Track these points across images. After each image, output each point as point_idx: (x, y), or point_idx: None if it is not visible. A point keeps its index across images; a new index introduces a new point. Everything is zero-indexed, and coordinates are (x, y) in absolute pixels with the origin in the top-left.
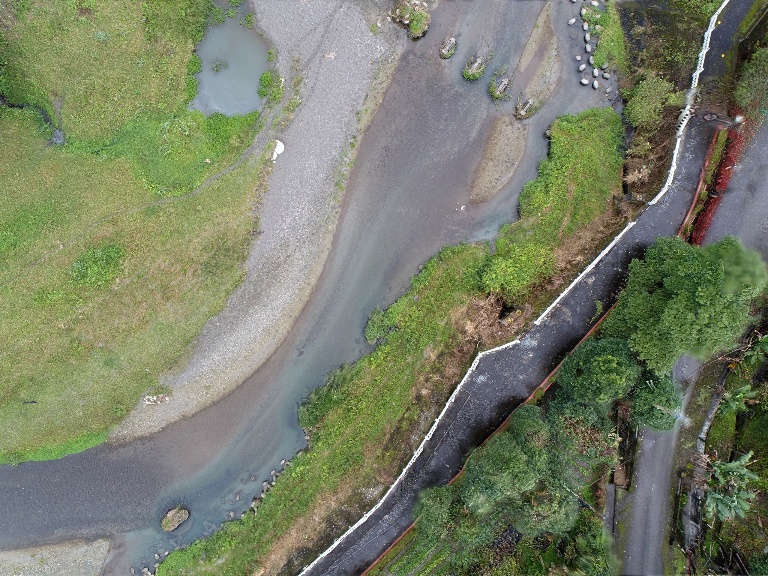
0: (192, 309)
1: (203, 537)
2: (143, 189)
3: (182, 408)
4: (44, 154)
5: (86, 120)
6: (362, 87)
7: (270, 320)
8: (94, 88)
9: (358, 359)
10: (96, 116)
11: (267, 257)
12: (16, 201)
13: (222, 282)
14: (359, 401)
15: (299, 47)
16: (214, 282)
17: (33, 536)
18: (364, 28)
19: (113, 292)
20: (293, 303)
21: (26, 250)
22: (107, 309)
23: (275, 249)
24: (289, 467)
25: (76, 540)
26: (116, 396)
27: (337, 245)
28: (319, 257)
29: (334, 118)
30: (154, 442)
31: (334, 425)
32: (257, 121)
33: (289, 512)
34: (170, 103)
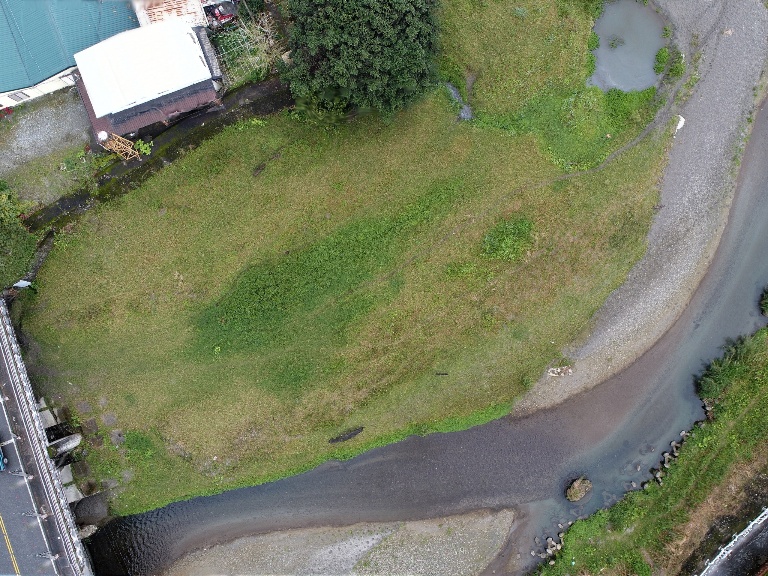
0: (598, 282)
1: (605, 507)
2: (551, 164)
3: (584, 380)
4: (456, 129)
5: (497, 95)
6: (758, 63)
7: (670, 293)
8: (509, 63)
9: (755, 331)
10: (507, 91)
11: (667, 231)
12: (429, 175)
13: (627, 255)
14: (763, 372)
15: (697, 24)
16: (620, 255)
17: (439, 506)
18: (760, 5)
19: (523, 265)
20: (692, 276)
21: (438, 224)
22: (518, 282)
23: (675, 223)
24: (692, 438)
25: (481, 510)
26: (522, 368)
27: (732, 219)
28: (717, 231)
29: (732, 94)
30: (556, 414)
31: (738, 396)
32: (656, 97)
33: (701, 481)
34: (574, 79)
